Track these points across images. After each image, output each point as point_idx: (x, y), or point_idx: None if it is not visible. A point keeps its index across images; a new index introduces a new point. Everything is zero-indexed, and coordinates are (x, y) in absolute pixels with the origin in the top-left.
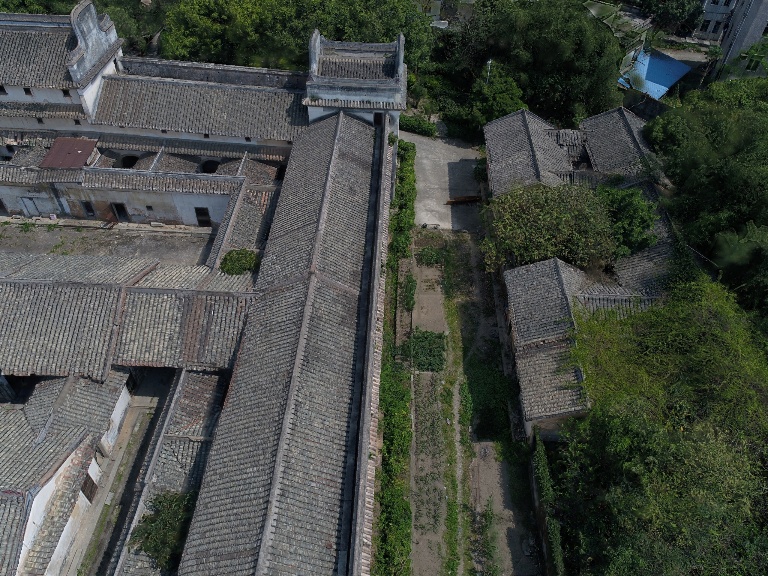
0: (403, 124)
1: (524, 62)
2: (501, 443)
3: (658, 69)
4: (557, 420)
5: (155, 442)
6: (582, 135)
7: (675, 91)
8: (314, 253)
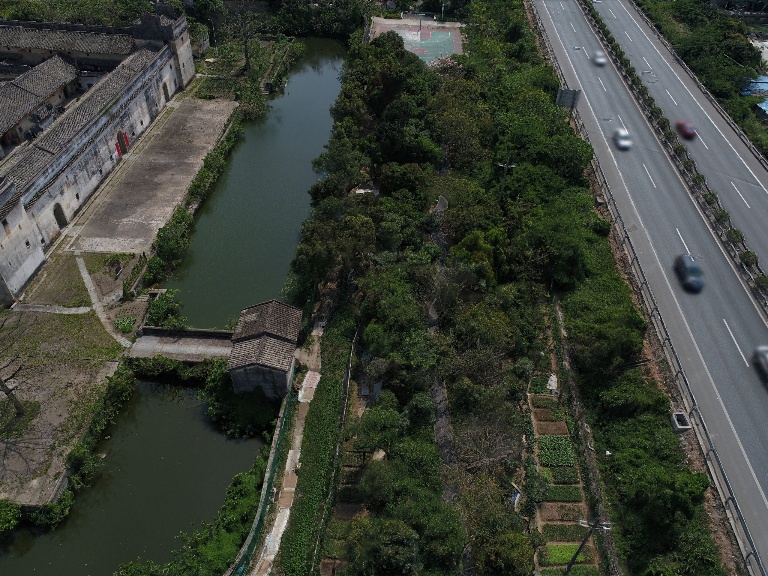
0: None
1: None
2: None
3: None
4: None
5: None
6: None
7: None
8: None
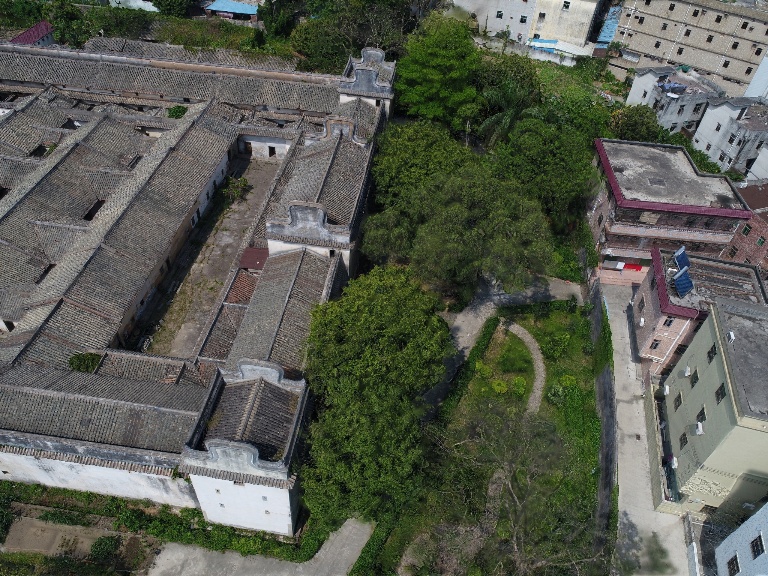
0: None
1: None
2: None
3: None
4: None
5: None
6: None
7: None
8: None
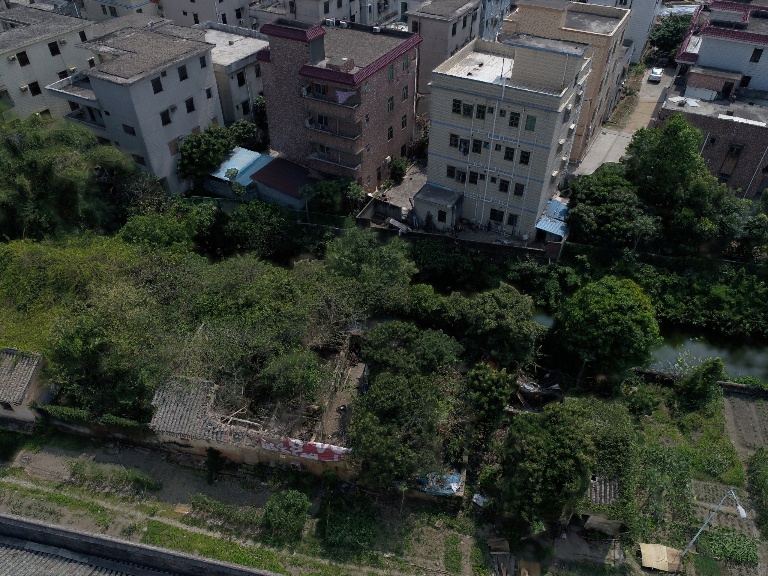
0: None
1: None
2: (27, 444)
3: None
4: (35, 385)
5: None
6: None
7: None
8: None
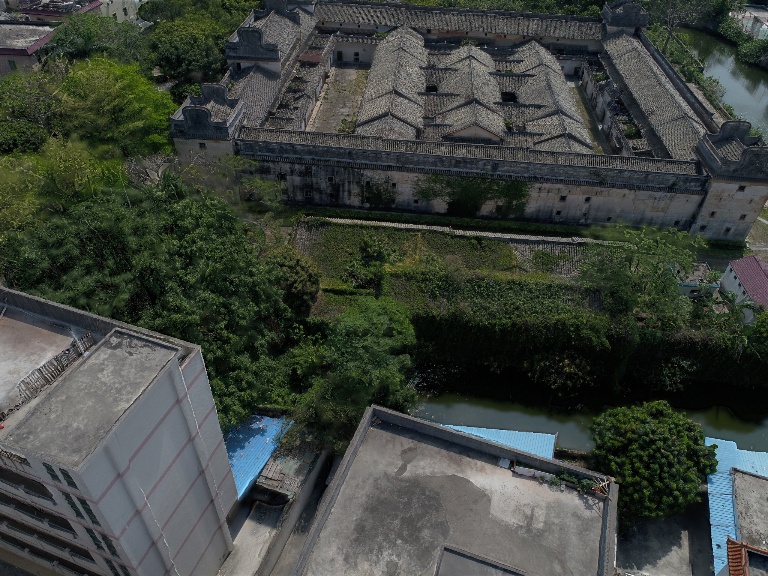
0: None
1: None
2: None
3: None
4: None
5: (445, 50)
6: None
7: None
8: (398, 8)
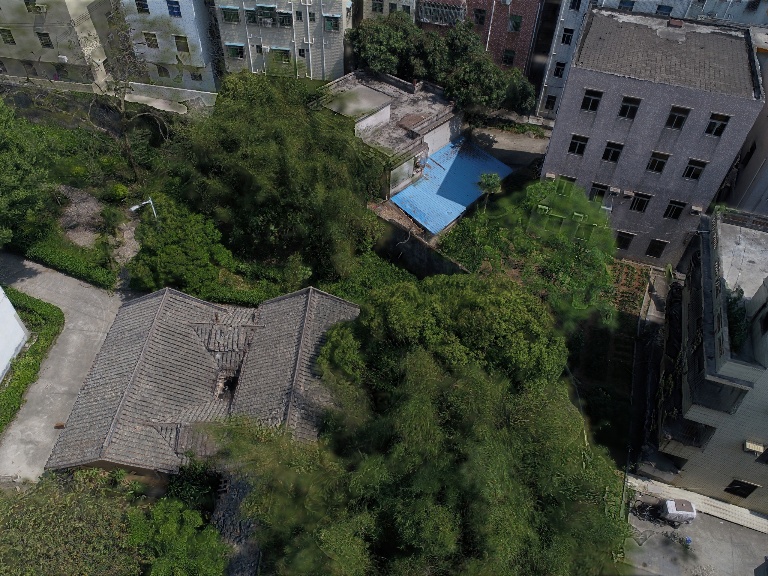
0: (70, 270)
1: (220, 192)
2: None
3: (462, 175)
4: None
5: None
6: (249, 332)
7: (475, 211)
8: None
